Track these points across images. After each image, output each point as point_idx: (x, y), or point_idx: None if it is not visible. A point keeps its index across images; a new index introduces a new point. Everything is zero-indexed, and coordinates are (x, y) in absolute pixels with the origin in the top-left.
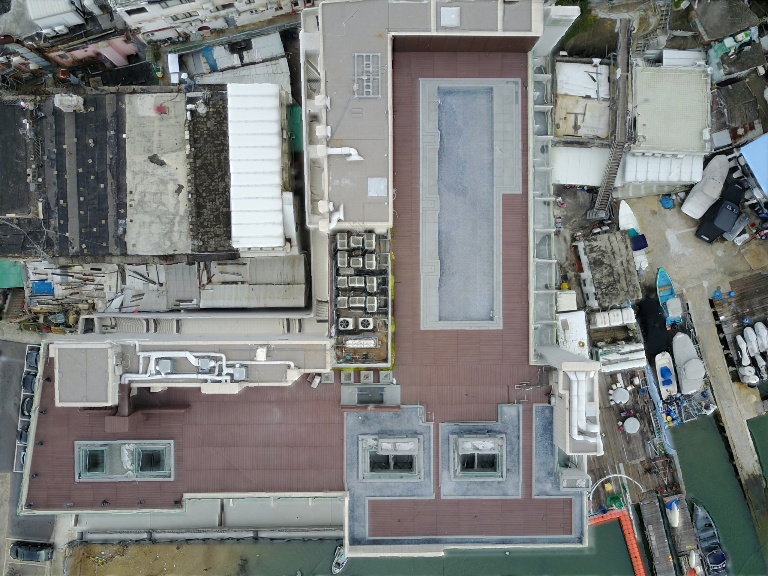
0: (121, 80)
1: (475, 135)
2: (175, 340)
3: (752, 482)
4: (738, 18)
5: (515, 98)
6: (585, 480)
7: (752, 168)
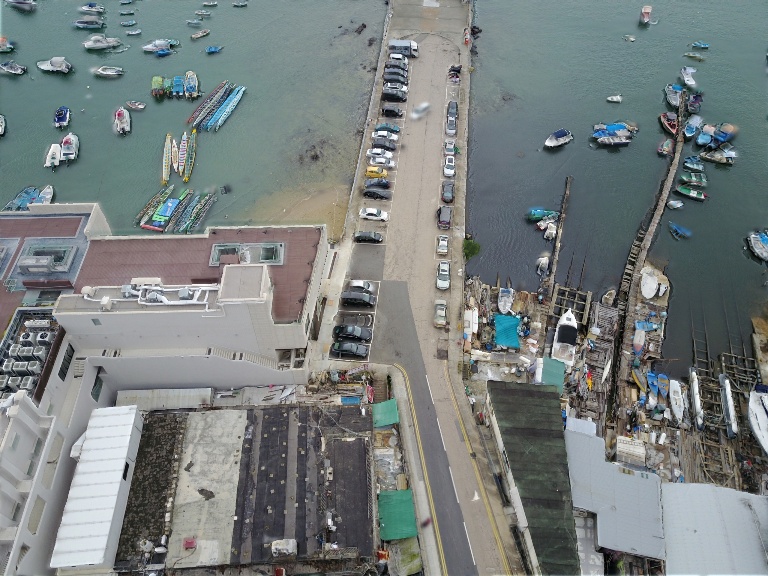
0: None
1: None
2: (179, 315)
3: None
4: None
5: None
6: None
7: None
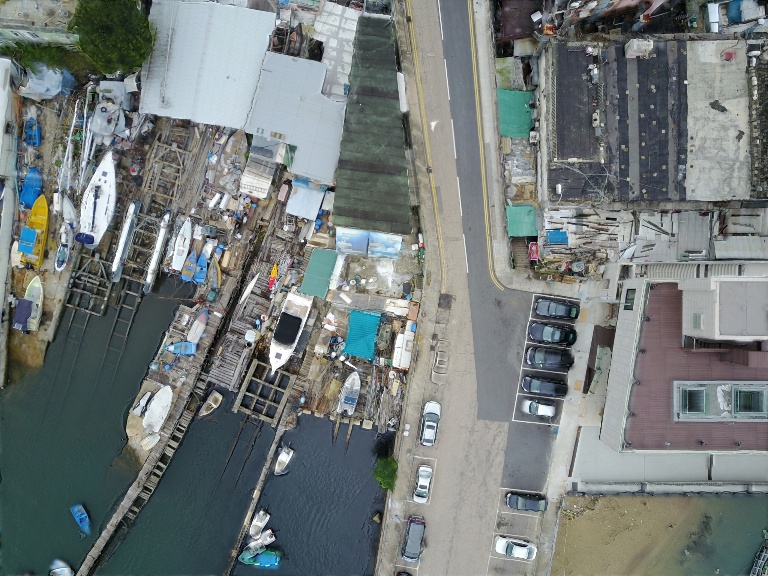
0: (640, 32)
1: None
2: None
3: None
4: None
5: None
6: None
7: None
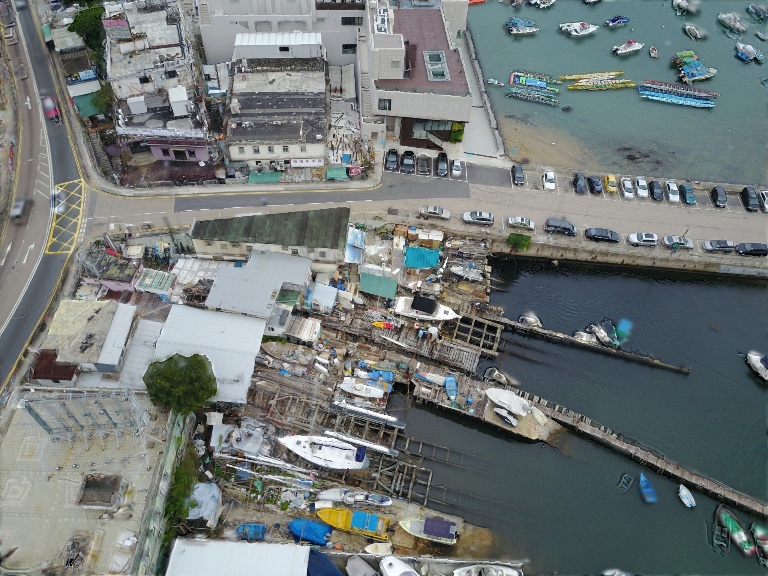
0: (218, 126)
1: None
2: None
3: None
4: None
5: None
6: None
7: None
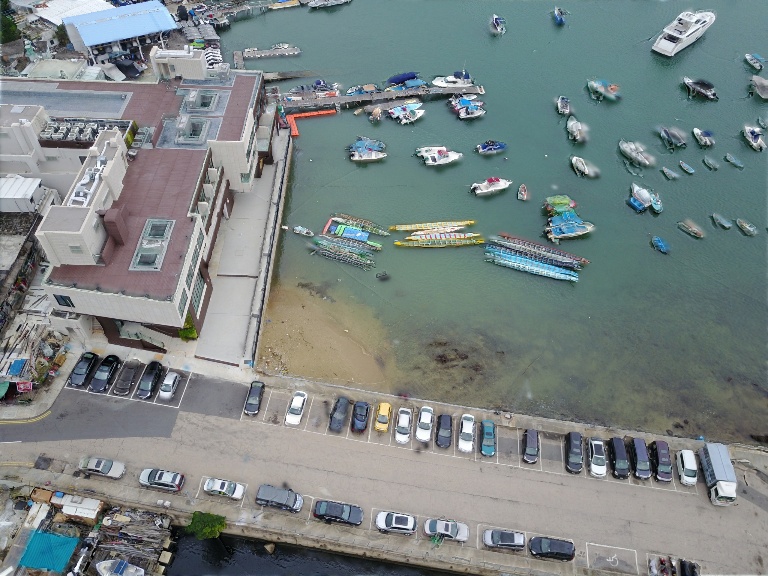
0: None
1: (17, 102)
2: None
3: (282, 75)
4: (16, 44)
5: (3, 83)
6: (223, 65)
7: (98, 43)
